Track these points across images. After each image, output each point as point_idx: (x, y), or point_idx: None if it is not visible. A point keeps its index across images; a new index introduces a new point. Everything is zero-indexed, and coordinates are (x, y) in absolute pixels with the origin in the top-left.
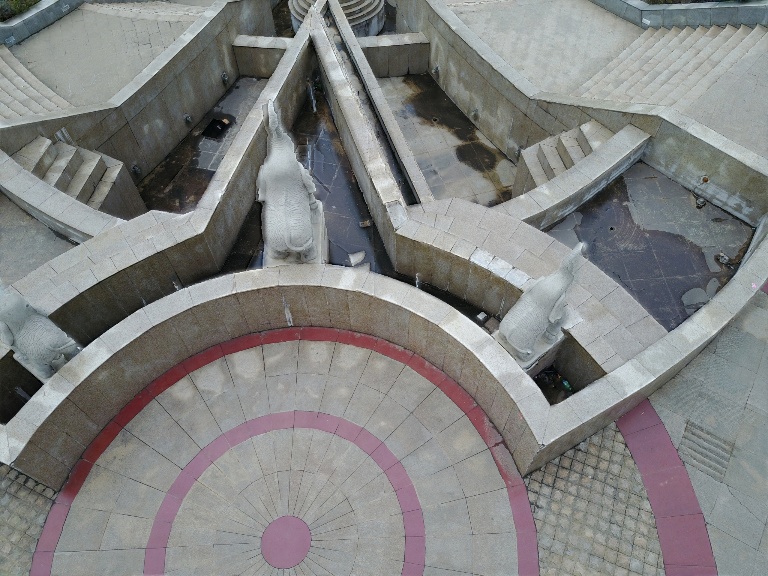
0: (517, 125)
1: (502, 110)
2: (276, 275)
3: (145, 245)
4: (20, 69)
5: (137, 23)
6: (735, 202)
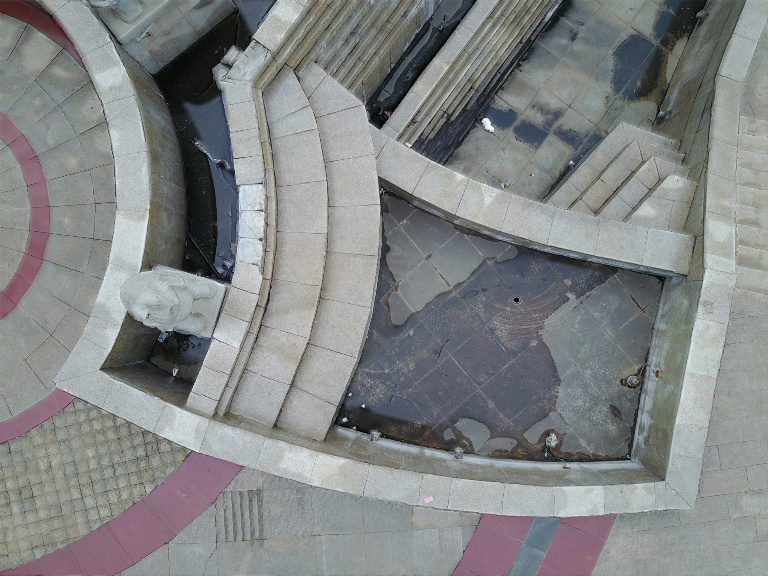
0: (690, 86)
1: (706, 50)
2: (61, 2)
3: None
4: None
5: None
6: (646, 422)
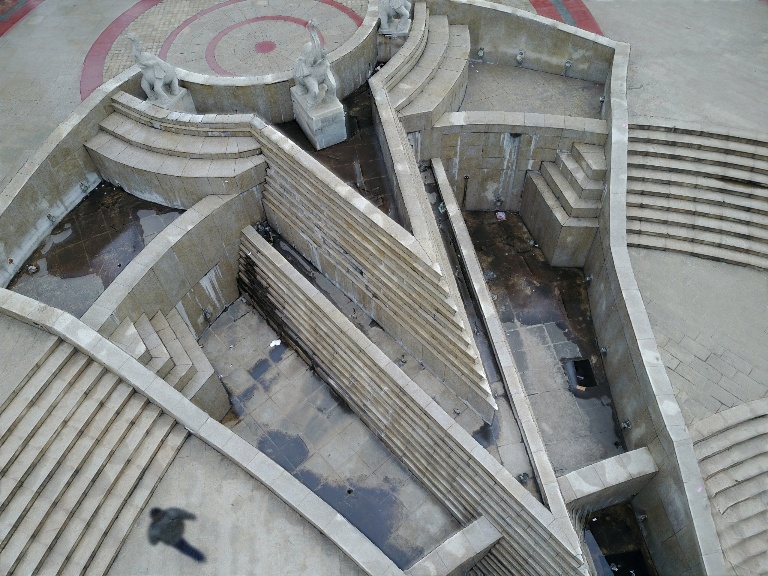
0: None
1: None
2: None
3: (394, 66)
4: (767, 263)
5: (760, 387)
6: None
